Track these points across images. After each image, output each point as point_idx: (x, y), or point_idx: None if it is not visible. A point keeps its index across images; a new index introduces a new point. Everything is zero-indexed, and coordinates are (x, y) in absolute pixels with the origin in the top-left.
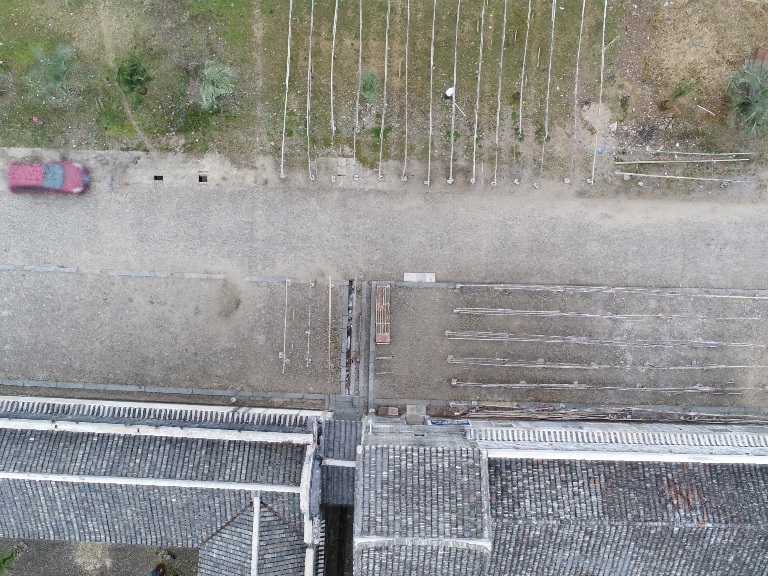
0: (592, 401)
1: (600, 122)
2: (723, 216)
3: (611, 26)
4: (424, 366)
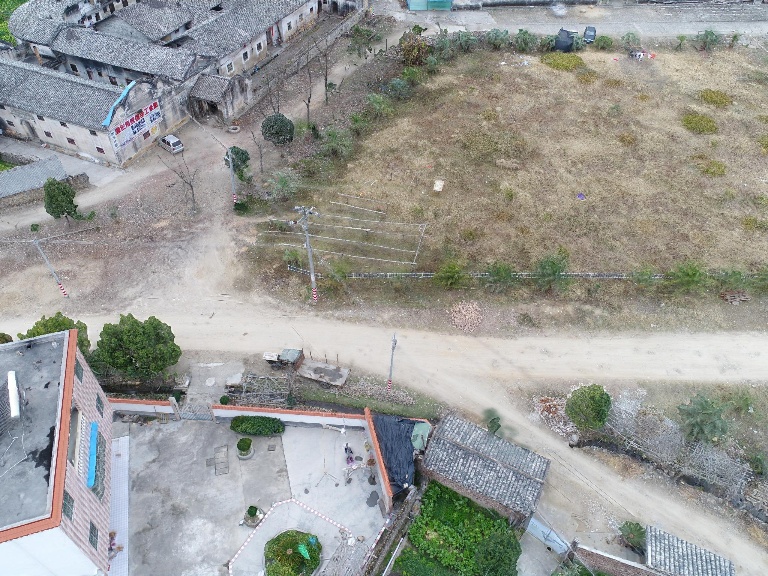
0: (706, 6)
1: (750, 45)
2: (692, 32)
3: (765, 61)
4: (763, 9)
